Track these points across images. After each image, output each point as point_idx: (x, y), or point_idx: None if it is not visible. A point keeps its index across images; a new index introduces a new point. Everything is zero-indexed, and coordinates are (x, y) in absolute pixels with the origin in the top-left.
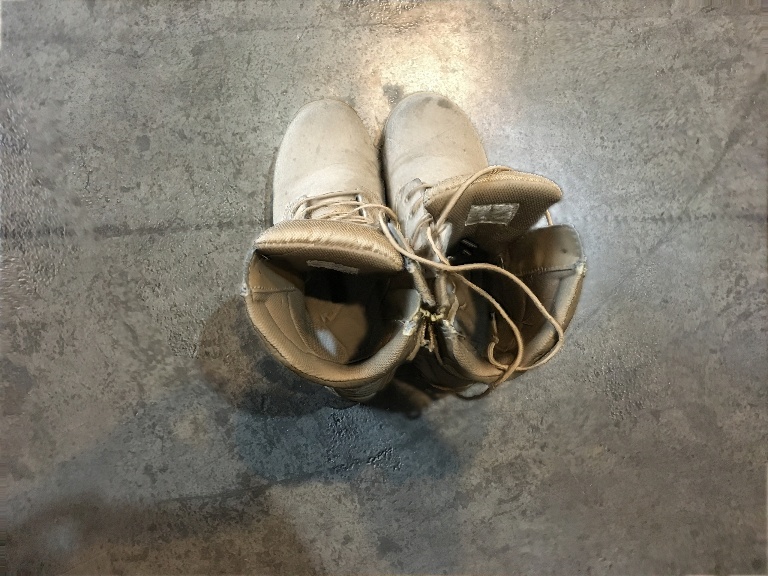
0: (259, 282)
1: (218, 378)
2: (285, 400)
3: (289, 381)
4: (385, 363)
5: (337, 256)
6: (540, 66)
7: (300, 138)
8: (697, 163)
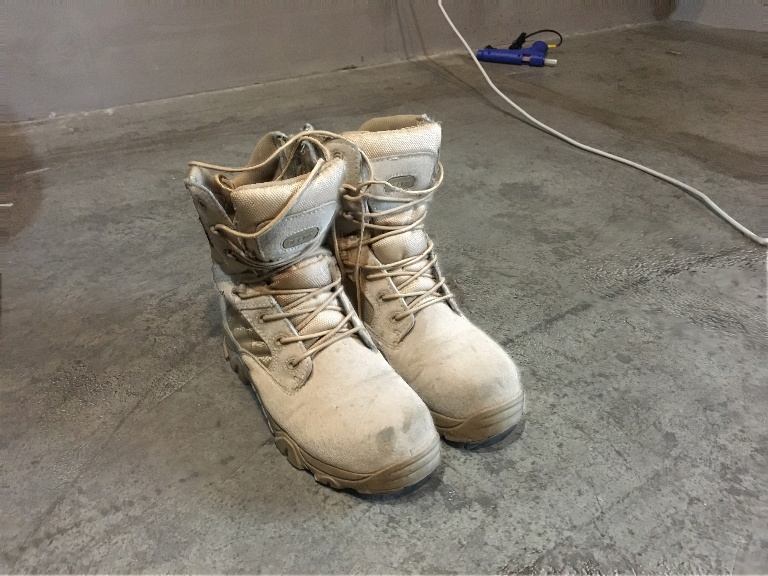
0: None
1: None
2: None
3: None
4: None
5: None
6: None
7: (497, 354)
8: None
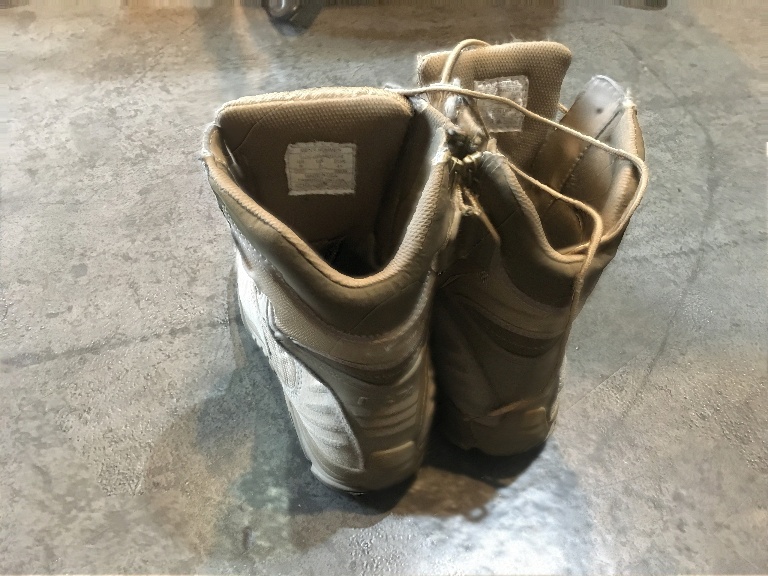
0: (225, 162)
1: (173, 517)
2: (279, 530)
3: (282, 501)
4: (418, 225)
5: (325, 115)
6: None
7: None
8: (689, 205)
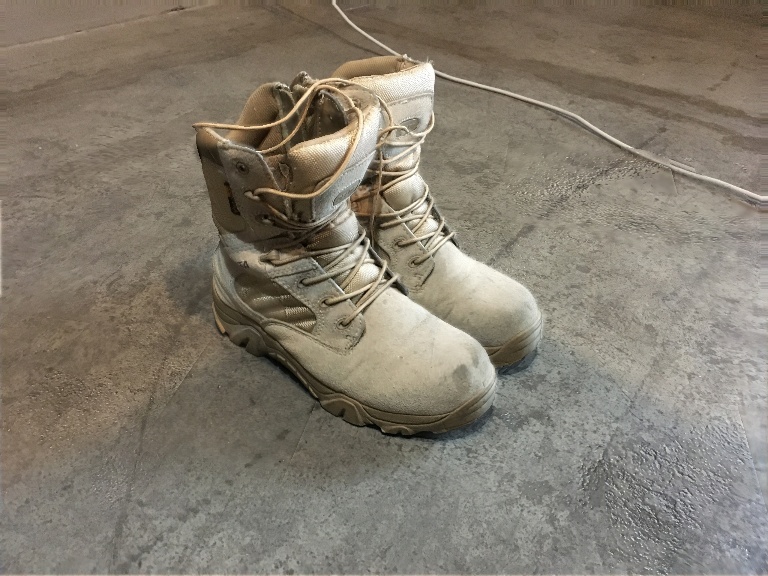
0: None
1: None
2: None
3: None
4: None
5: None
6: (440, 575)
7: (510, 281)
8: None
